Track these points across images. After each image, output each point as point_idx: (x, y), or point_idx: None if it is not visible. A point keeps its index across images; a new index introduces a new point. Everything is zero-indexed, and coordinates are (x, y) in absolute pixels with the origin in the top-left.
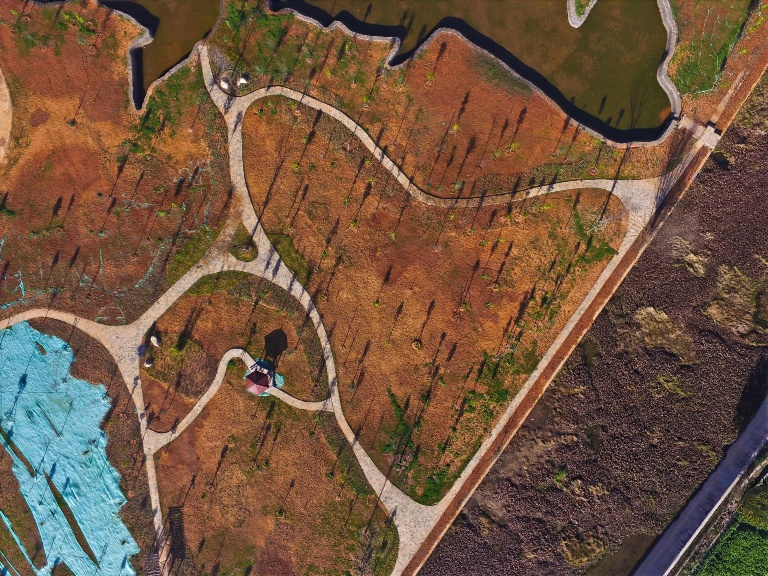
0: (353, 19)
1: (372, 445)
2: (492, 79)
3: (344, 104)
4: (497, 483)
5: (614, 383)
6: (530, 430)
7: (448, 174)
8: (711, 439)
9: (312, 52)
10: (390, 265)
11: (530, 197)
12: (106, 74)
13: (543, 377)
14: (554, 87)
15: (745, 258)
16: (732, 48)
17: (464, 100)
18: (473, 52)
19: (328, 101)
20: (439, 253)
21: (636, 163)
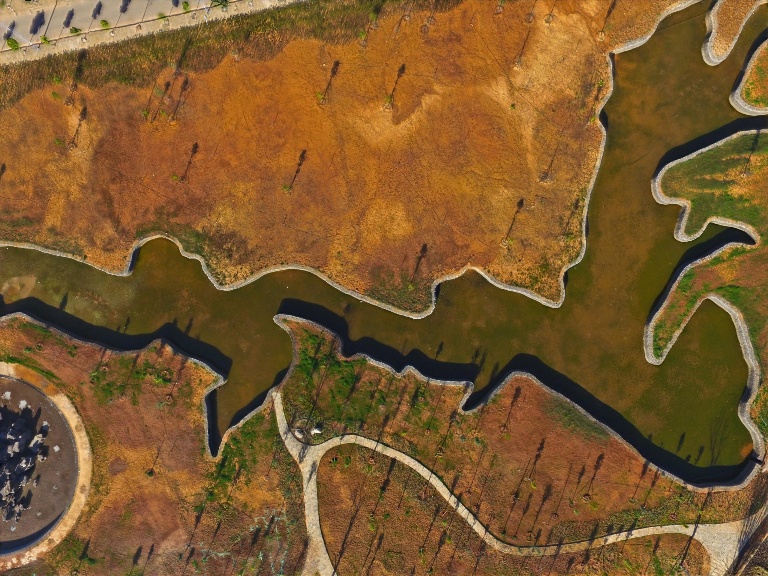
0: (425, 357)
1: None
2: (568, 425)
3: (418, 452)
4: None
5: None
6: None
7: (524, 522)
8: None
9: (385, 398)
10: None
11: (608, 544)
12: (183, 423)
13: None
14: (631, 424)
15: None
16: None
17: (540, 446)
18: (548, 396)
19: (402, 449)
20: None
21: (718, 508)
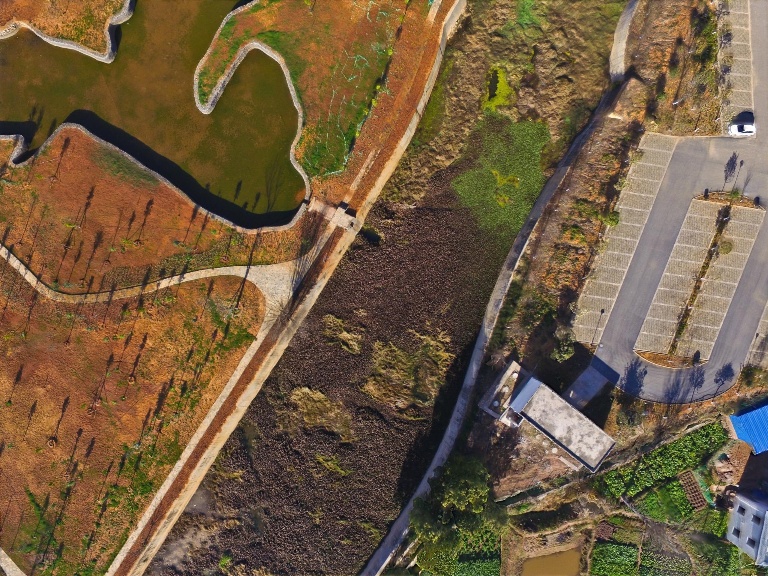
0: None
1: (12, 546)
2: (117, 172)
3: None
4: (162, 571)
5: (274, 465)
6: (192, 516)
7: (76, 270)
8: (374, 516)
9: None
10: (21, 364)
11: (162, 288)
12: None
13: (187, 467)
14: (188, 175)
15: (399, 333)
16: (360, 128)
17: (89, 195)
18: (97, 146)
19: None
20: (71, 349)
21: (268, 248)
